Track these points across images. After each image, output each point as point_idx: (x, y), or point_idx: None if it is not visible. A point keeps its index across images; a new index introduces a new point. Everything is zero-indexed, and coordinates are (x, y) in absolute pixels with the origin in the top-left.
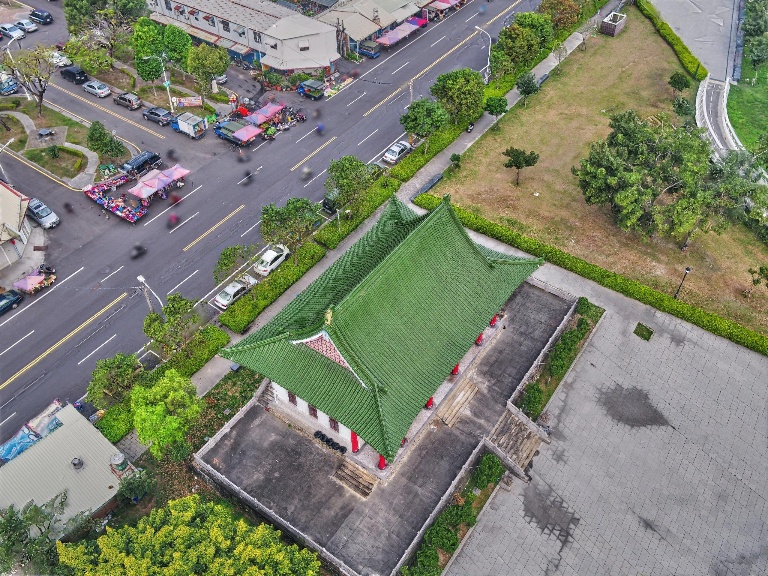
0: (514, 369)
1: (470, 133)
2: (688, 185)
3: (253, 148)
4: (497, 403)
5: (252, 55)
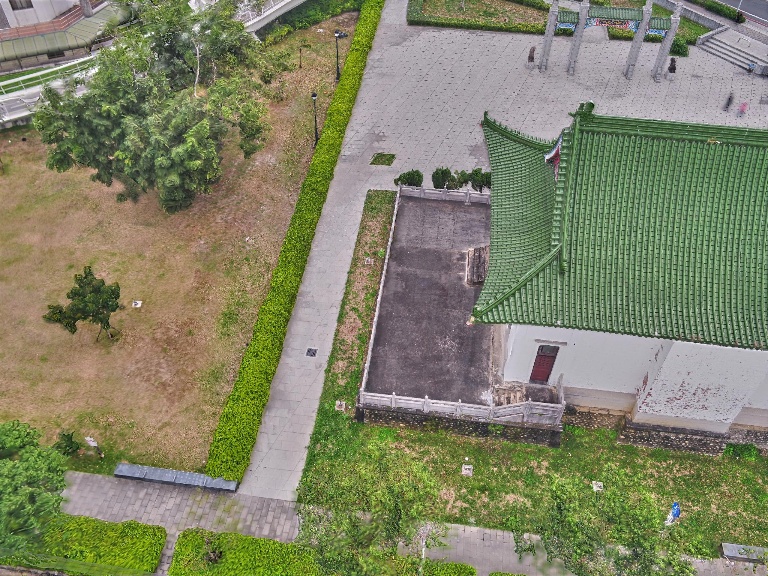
0: None
1: None
2: (228, 42)
3: None
4: None
5: None
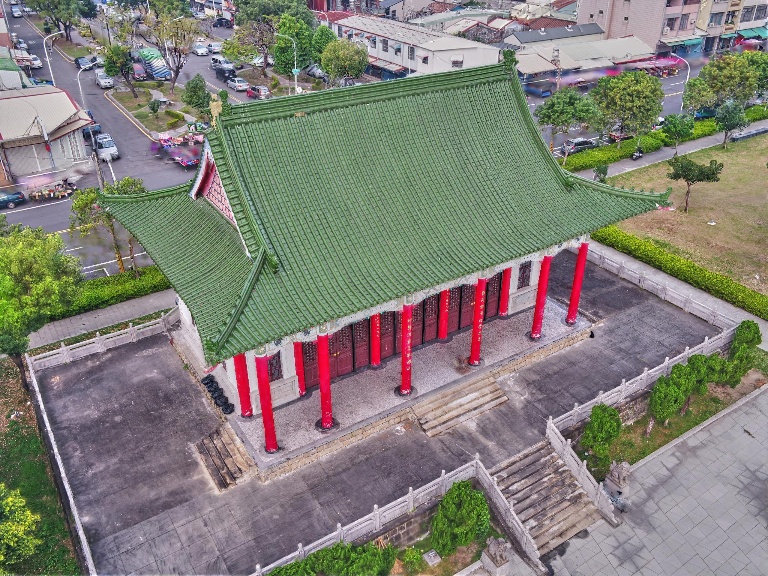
0: (585, 390)
1: (635, 161)
2: None
3: None
4: (532, 426)
5: None
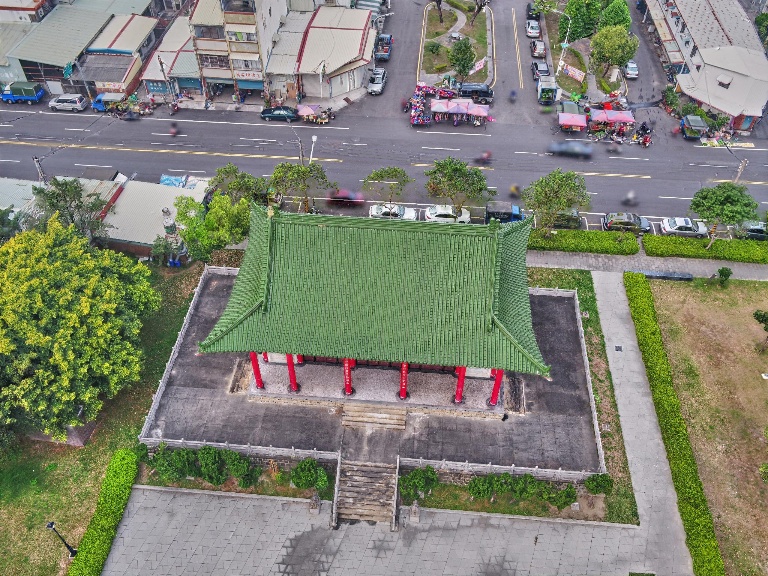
0: (454, 451)
1: None
2: None
3: (569, 137)
4: None
5: (684, 69)
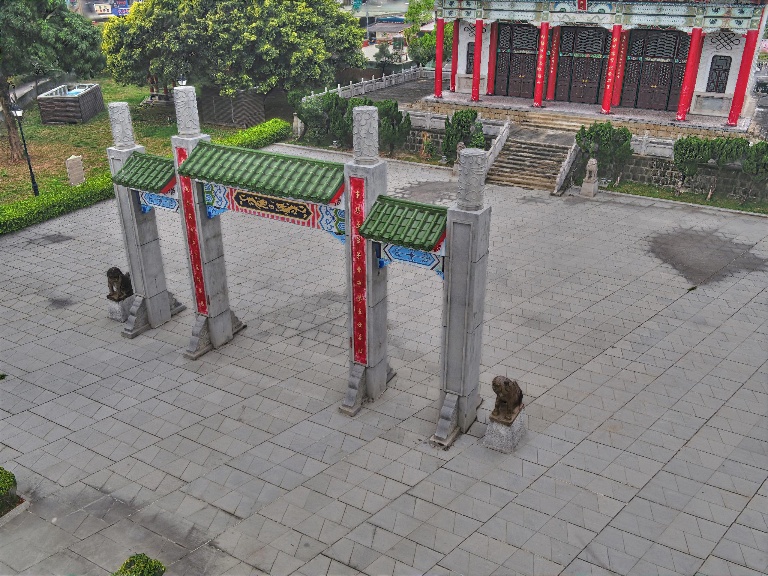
0: None
1: None
2: None
3: None
4: None
5: None
